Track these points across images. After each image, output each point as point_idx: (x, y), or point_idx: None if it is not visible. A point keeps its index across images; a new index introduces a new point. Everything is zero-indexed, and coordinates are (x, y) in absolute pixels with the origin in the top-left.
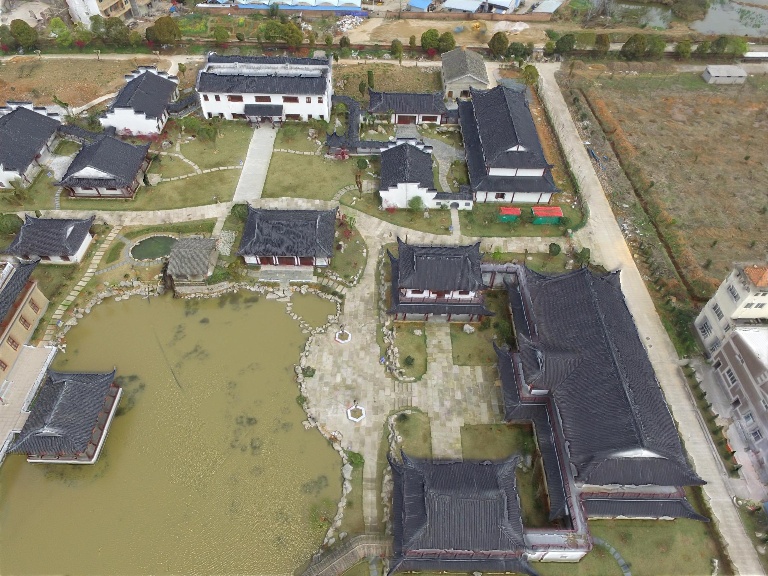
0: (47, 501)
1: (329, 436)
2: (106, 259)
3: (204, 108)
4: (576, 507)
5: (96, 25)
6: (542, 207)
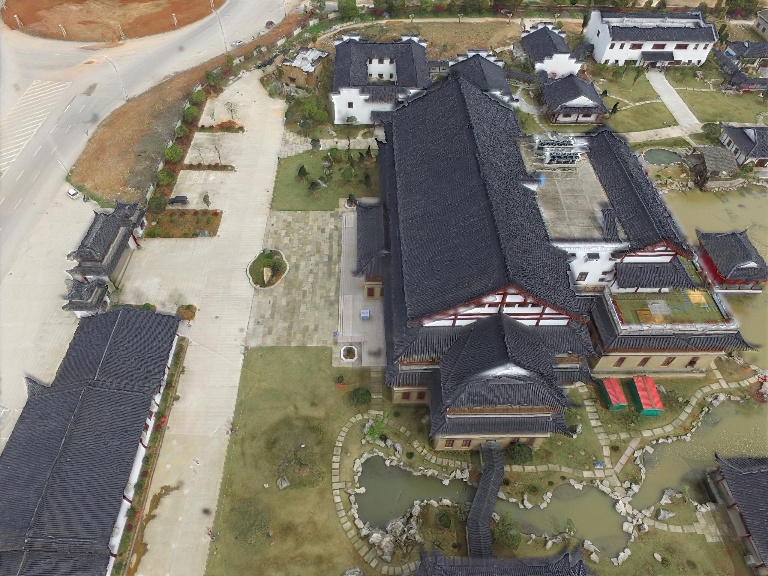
0: (745, 317)
1: None
2: None
3: (605, 56)
4: None
5: None
6: None
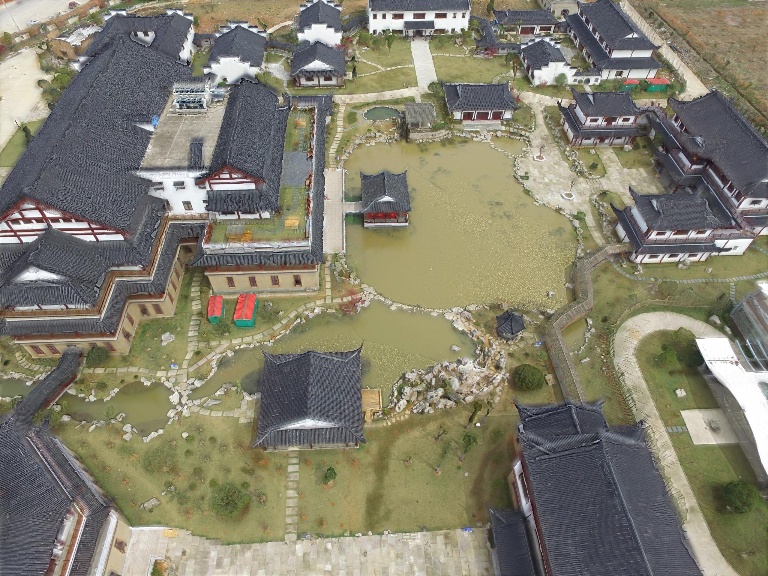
0: (386, 246)
1: (555, 208)
2: (347, 122)
3: (371, 26)
4: (741, 217)
5: None
6: (653, 79)
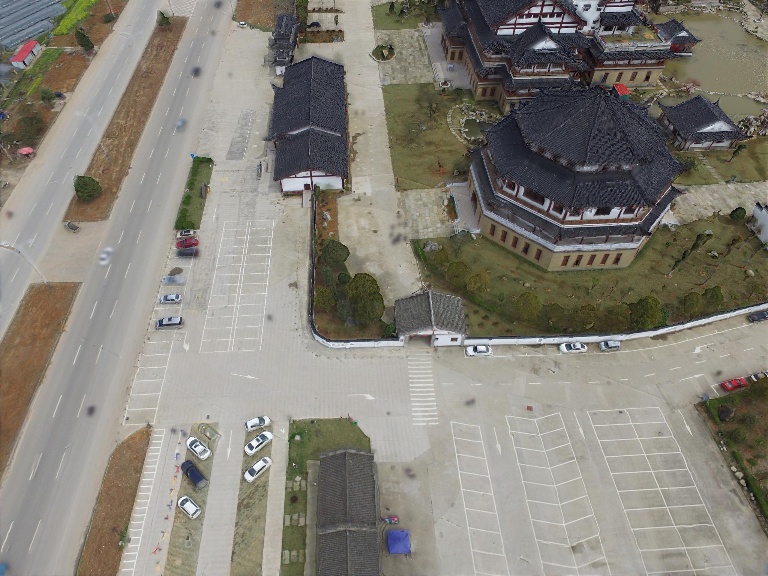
0: (681, 67)
1: None
2: None
3: None
4: None
5: None
6: None
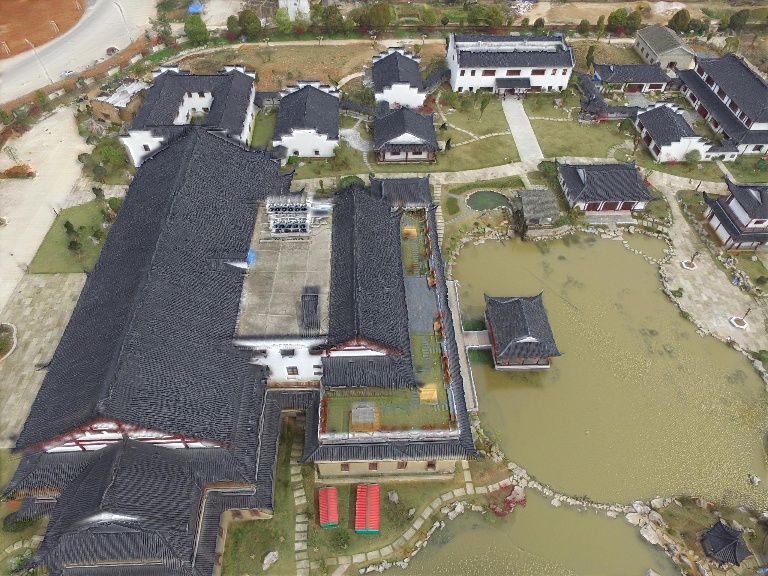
0: (525, 398)
1: (726, 341)
2: (447, 211)
3: (457, 83)
4: None
5: (318, 13)
6: None
